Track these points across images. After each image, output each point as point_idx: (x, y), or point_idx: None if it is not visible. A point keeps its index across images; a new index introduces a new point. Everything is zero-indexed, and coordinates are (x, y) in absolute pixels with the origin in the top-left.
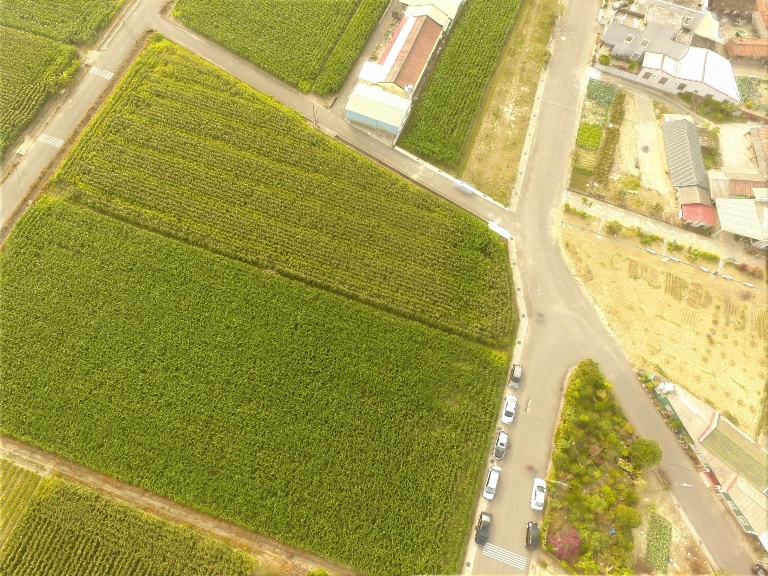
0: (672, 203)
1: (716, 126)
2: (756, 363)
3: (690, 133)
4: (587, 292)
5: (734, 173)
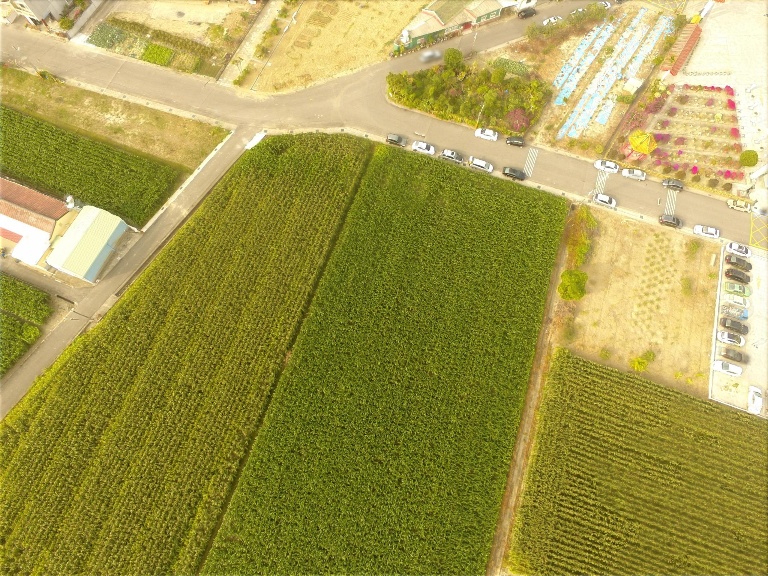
0: (240, 6)
1: None
2: None
3: None
4: (322, 81)
5: None
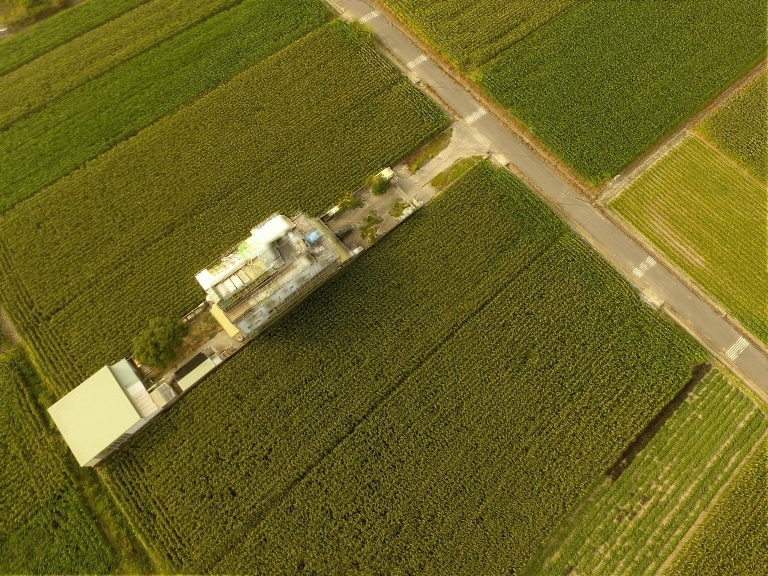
0: None
1: None
2: None
3: None
4: None
5: None
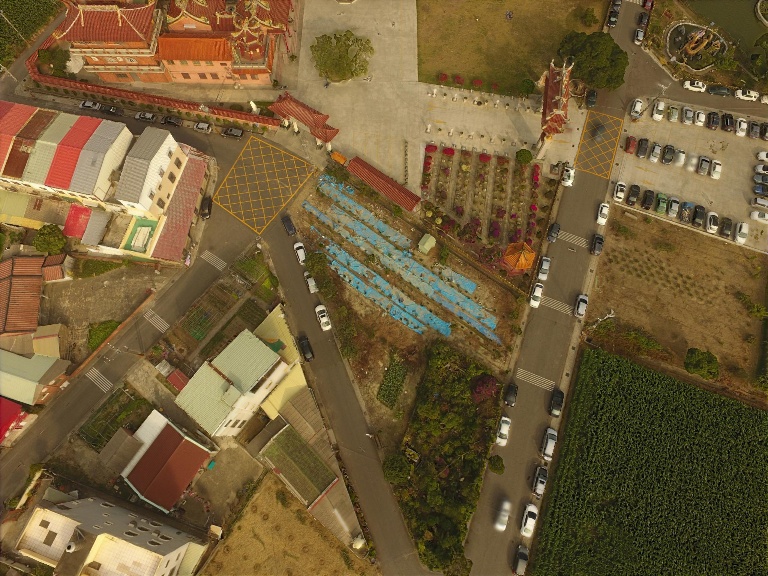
0: None
1: None
2: (227, 567)
3: None
4: None
5: None
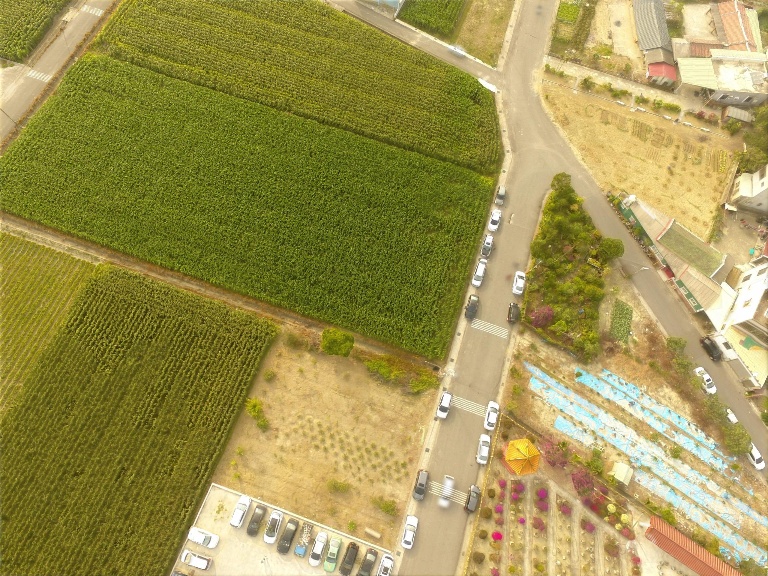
0: (640, 66)
1: (680, 3)
2: (710, 190)
3: (657, 7)
4: (564, 134)
5: (695, 39)
